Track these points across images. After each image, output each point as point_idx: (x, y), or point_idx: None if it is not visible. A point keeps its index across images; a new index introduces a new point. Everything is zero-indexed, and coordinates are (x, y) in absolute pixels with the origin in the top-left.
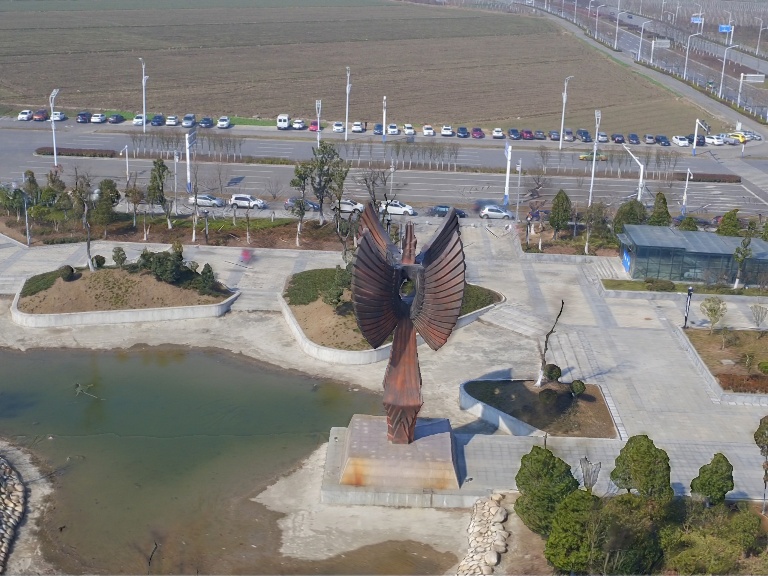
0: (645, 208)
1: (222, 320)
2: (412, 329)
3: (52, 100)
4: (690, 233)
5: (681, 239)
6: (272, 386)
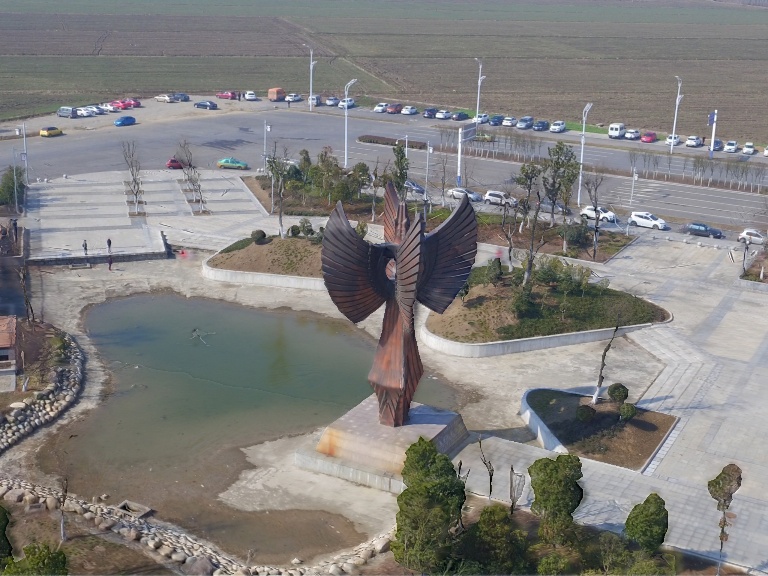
0: None
1: None
2: None
3: (347, 88)
4: None
5: None
6: (362, 361)
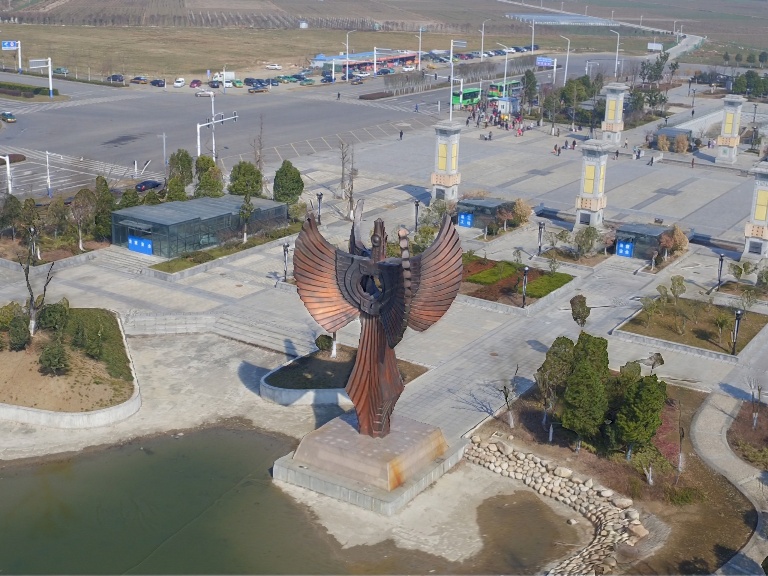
0: None
1: None
2: None
3: None
4: (165, 206)
5: None
6: (110, 469)
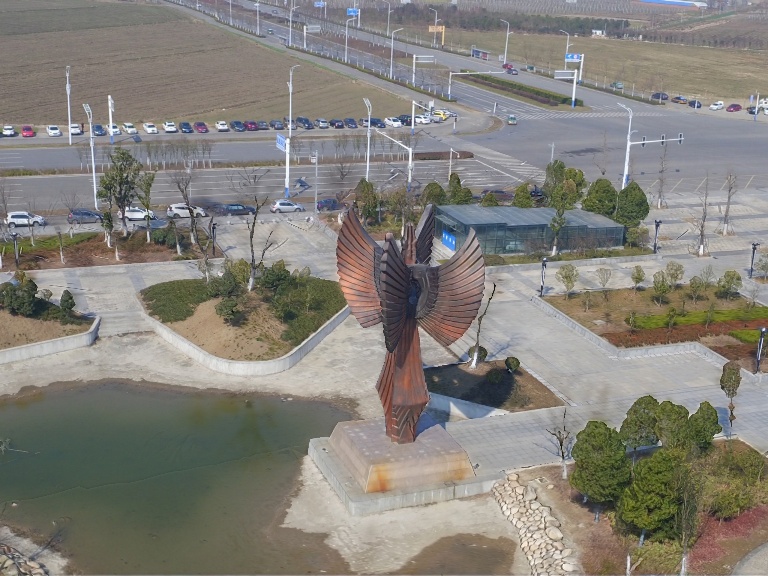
0: (443, 189)
1: (96, 349)
2: (415, 328)
3: None
4: (496, 208)
5: (495, 215)
6: (204, 409)
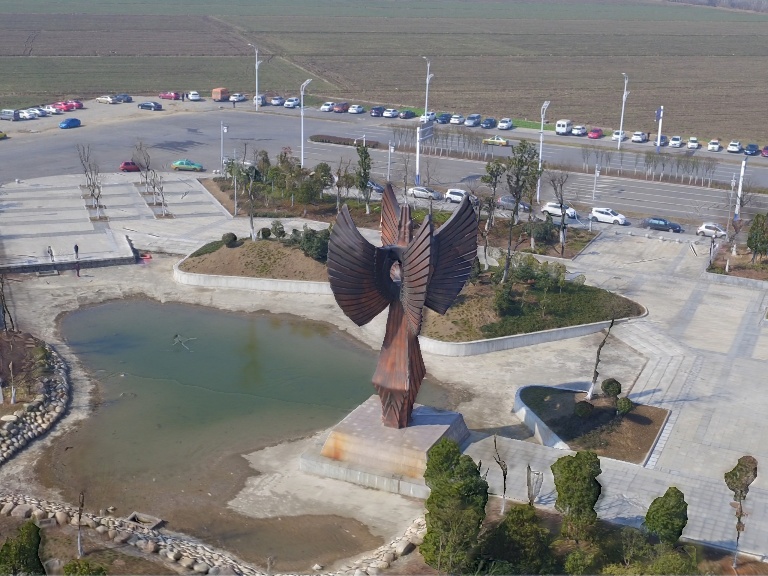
0: None
1: None
2: (404, 312)
3: (303, 88)
4: None
5: None
6: (349, 363)
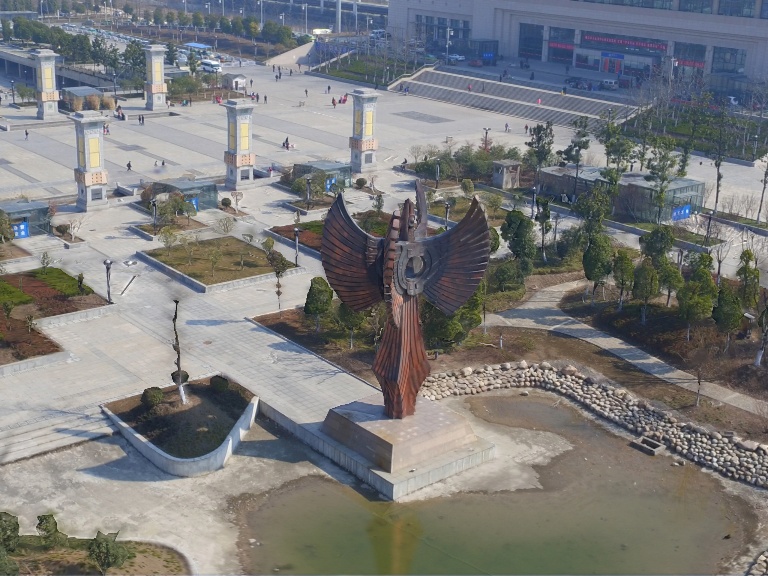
0: None
1: None
2: None
3: None
4: None
5: None
6: None
